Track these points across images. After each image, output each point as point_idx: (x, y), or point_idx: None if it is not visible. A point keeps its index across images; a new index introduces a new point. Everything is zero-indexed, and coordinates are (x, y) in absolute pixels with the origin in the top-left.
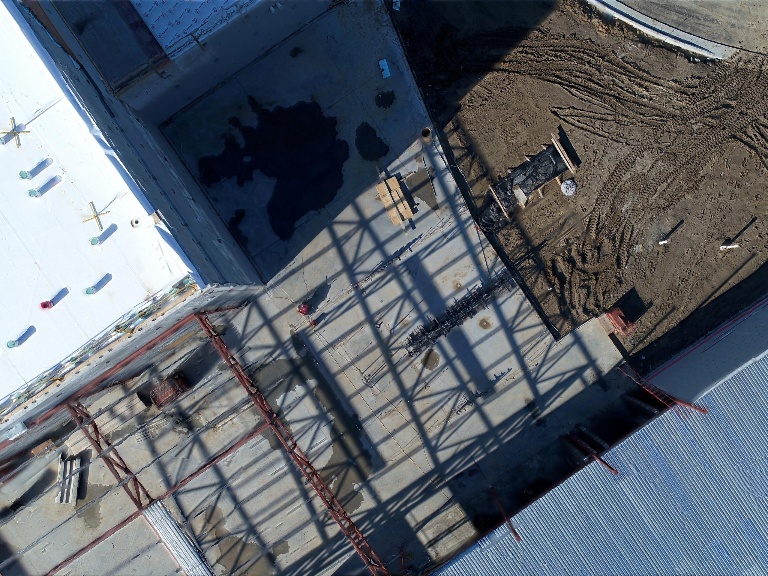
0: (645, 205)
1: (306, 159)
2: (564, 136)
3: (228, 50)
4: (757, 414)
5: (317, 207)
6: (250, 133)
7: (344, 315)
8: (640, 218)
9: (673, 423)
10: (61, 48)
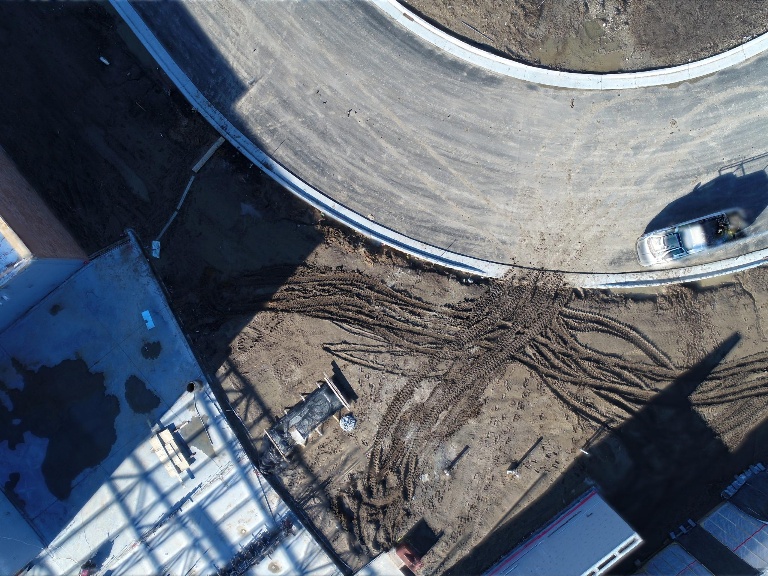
0: (427, 434)
1: (76, 418)
2: (338, 372)
3: None
4: None
5: (92, 465)
6: (17, 396)
7: (130, 570)
8: (423, 447)
9: None
10: None
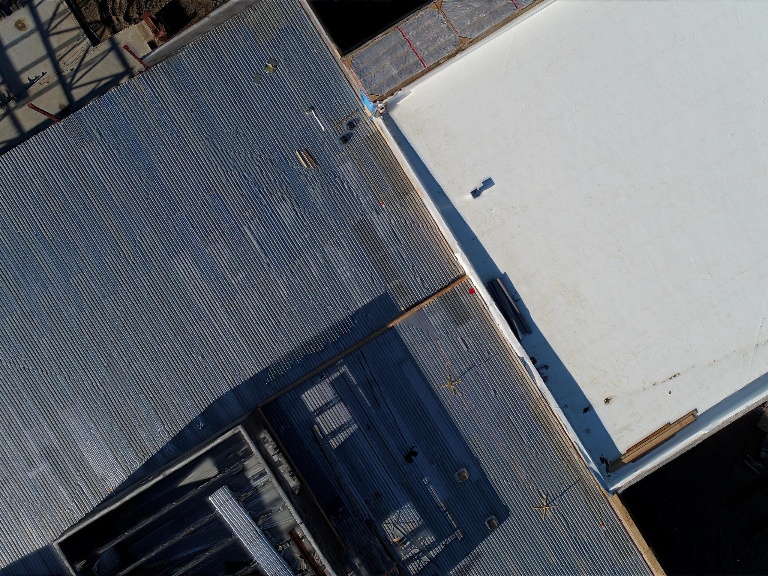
0: None
1: None
2: None
3: None
4: (229, 85)
5: None
6: None
7: None
8: None
9: (140, 89)
10: None
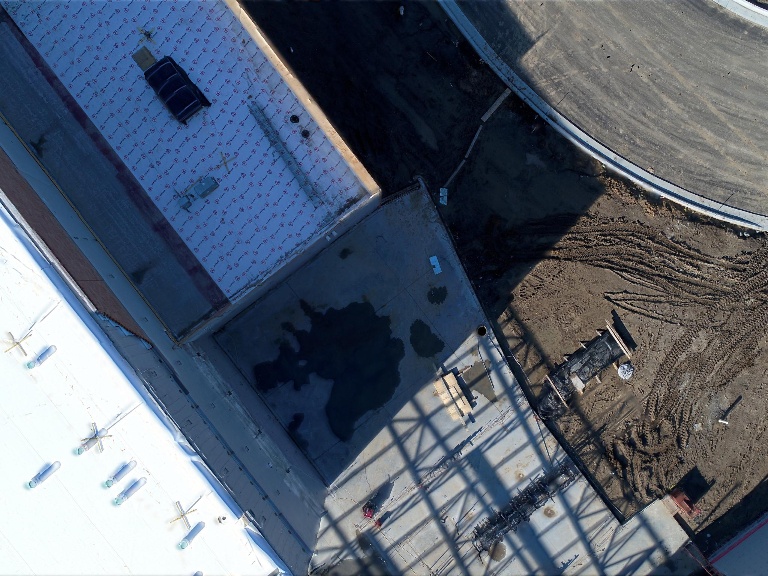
0: (702, 384)
1: (362, 360)
2: (618, 320)
3: (283, 272)
4: None
5: (376, 407)
6: (304, 337)
7: (408, 512)
8: (698, 397)
9: None
10: (134, 336)
